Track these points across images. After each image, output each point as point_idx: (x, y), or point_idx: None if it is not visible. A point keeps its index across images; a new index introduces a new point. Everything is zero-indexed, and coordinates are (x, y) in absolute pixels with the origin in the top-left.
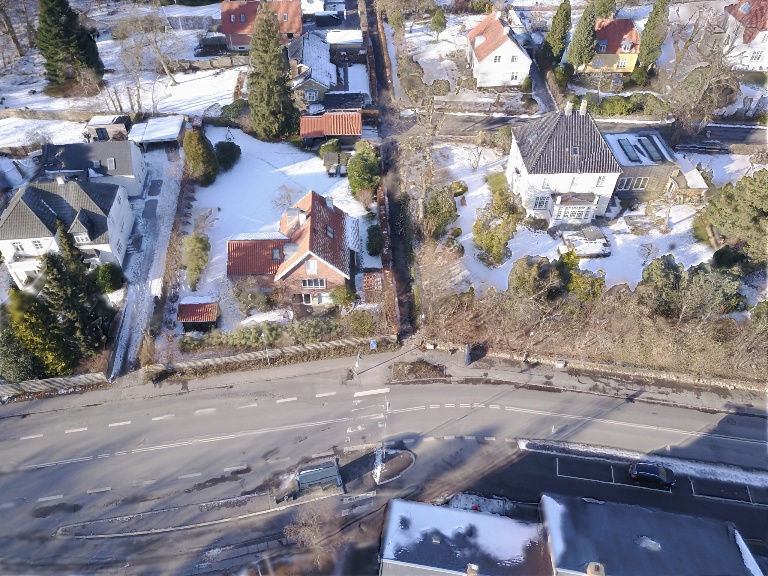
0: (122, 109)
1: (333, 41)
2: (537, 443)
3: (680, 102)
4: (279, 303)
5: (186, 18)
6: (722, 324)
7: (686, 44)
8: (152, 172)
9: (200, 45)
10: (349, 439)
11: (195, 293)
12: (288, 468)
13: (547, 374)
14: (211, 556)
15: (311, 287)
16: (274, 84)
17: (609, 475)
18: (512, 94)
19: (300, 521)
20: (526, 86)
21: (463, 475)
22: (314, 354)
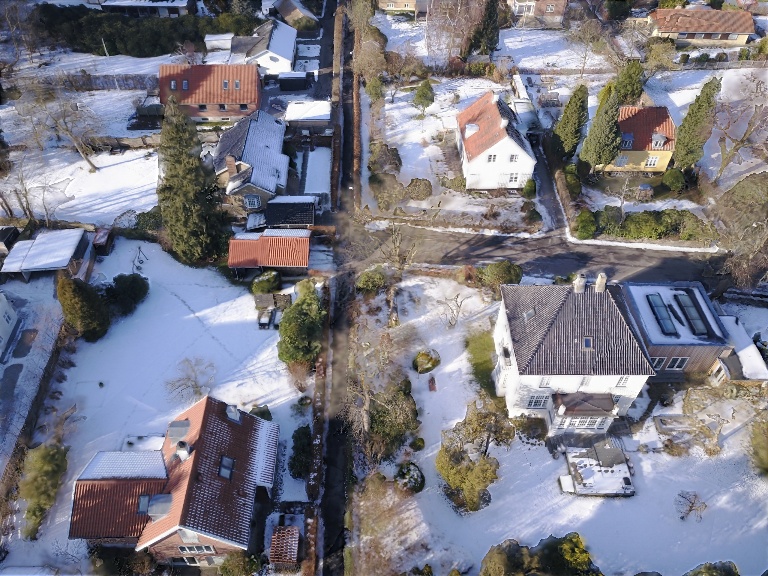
0: (13, 213)
1: (293, 117)
2: None
3: (733, 246)
4: None
5: (125, 77)
6: None
7: (736, 146)
8: (27, 316)
9: (136, 114)
10: None
11: (33, 544)
12: None
13: None
14: None
15: (194, 551)
16: (192, 201)
17: None
18: (510, 200)
19: None
20: (528, 191)
21: None
22: None
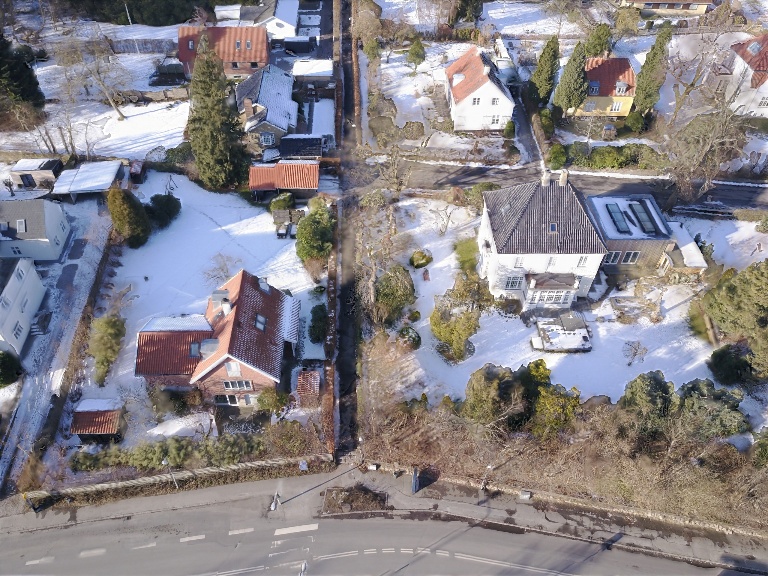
0: (55, 150)
1: (300, 73)
2: None
3: (678, 163)
4: (199, 405)
5: (144, 41)
6: (719, 451)
7: (687, 89)
8: (77, 229)
9: (156, 73)
10: None
11: (102, 390)
12: None
13: (509, 507)
14: None
15: (236, 388)
16: (219, 131)
17: None
18: (492, 139)
19: None
20: (508, 131)
21: None
22: (232, 476)
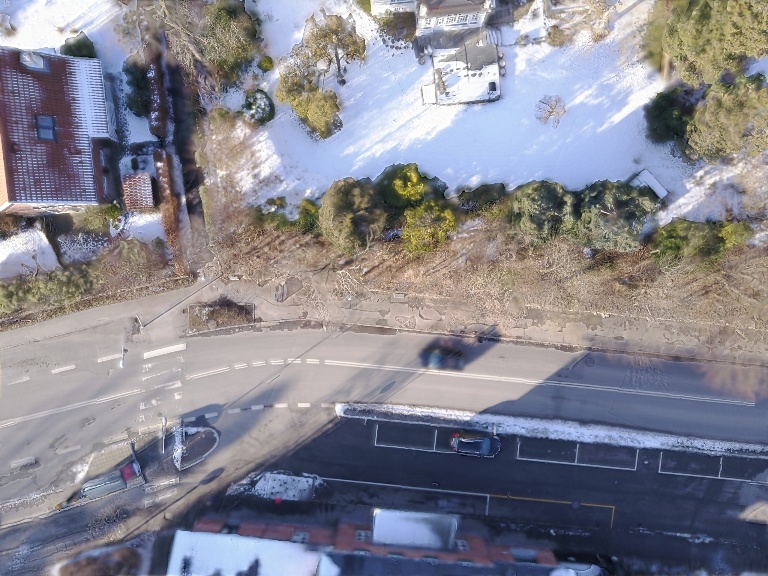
0: None
1: None
2: (357, 408)
3: None
4: (20, 223)
5: None
6: None
7: None
8: None
9: None
10: (143, 418)
11: None
12: (80, 459)
13: (382, 308)
14: (21, 558)
15: None
16: None
17: (431, 442)
18: None
19: (103, 518)
20: None
21: (272, 453)
22: None
